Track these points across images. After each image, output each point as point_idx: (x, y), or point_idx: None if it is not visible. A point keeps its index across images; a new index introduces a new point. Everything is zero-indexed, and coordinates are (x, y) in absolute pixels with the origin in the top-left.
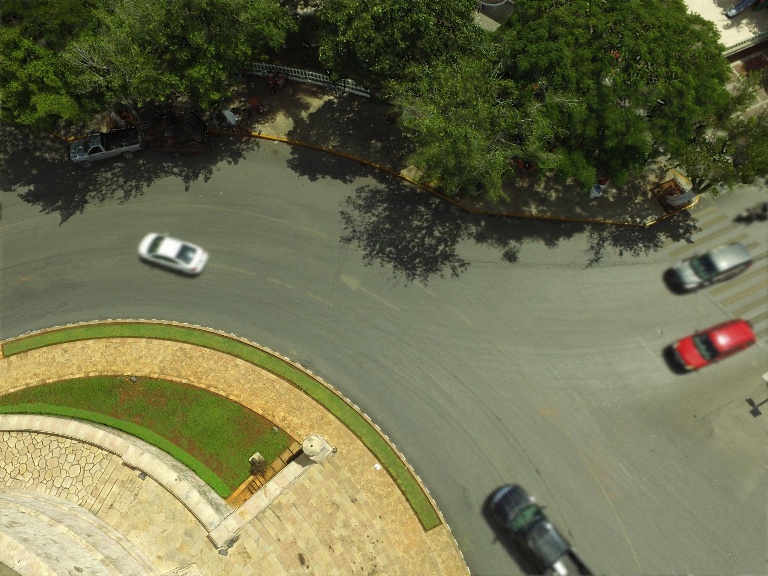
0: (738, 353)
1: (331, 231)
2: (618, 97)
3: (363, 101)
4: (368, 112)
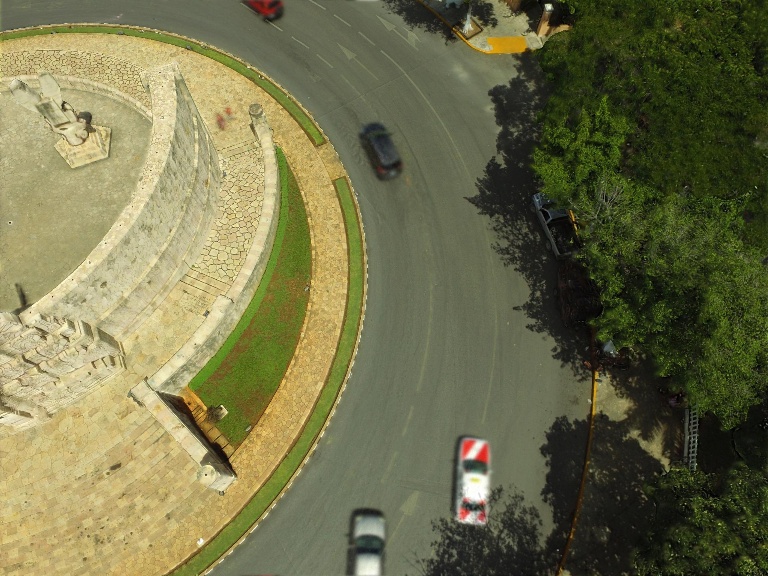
0: None
1: (475, 477)
2: None
3: None
4: None
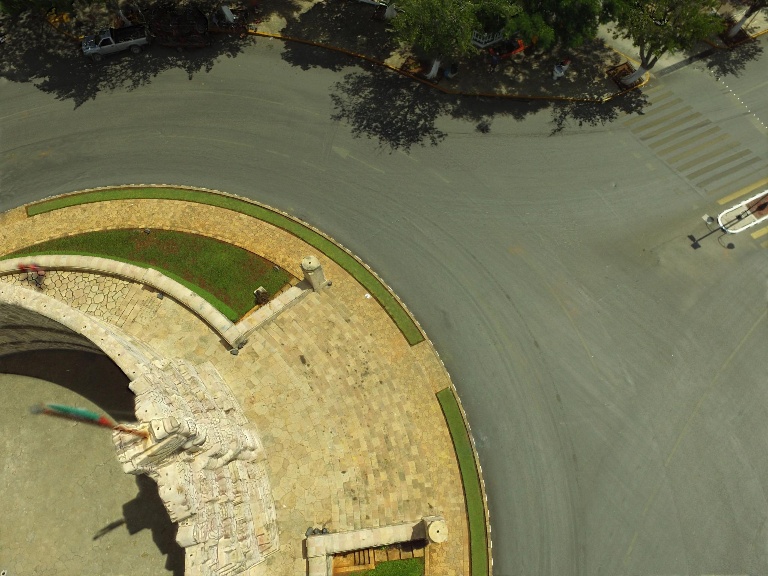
0: (681, 200)
1: (323, 110)
2: None
3: (349, 3)
4: (354, 12)
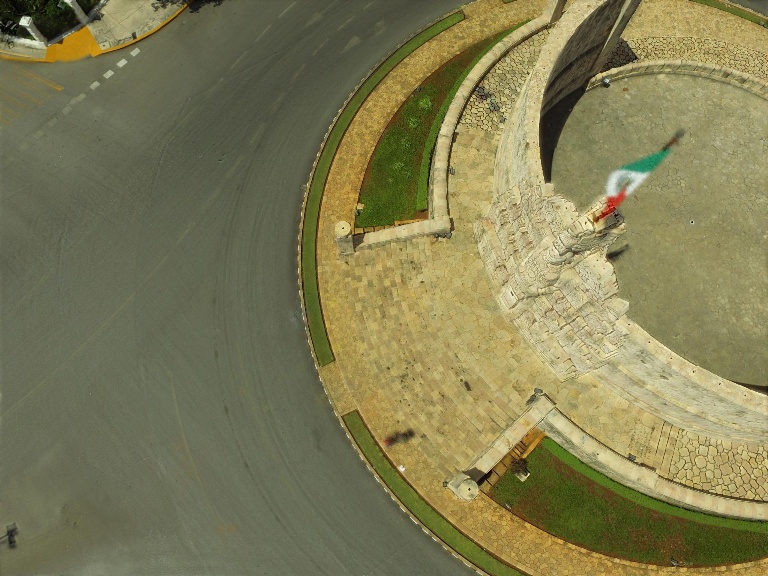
0: None
1: None
2: None
3: None
4: None
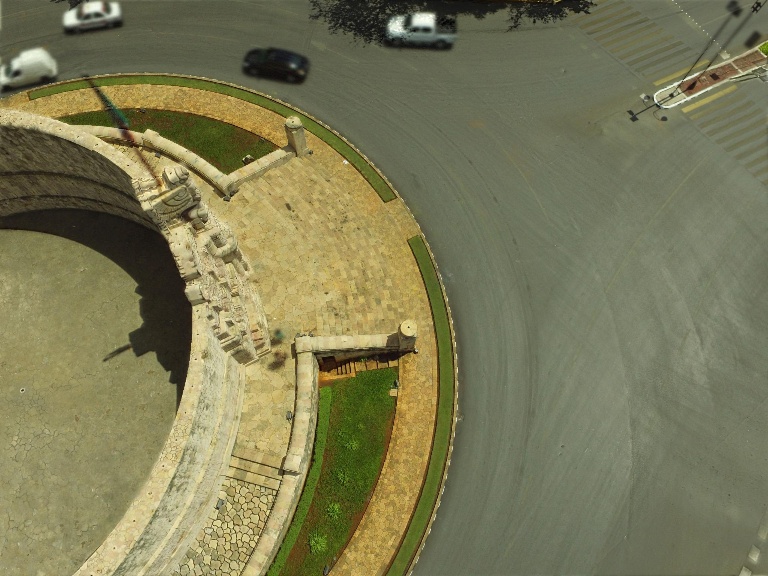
0: (622, 82)
1: (302, 11)
2: None
3: None
4: None
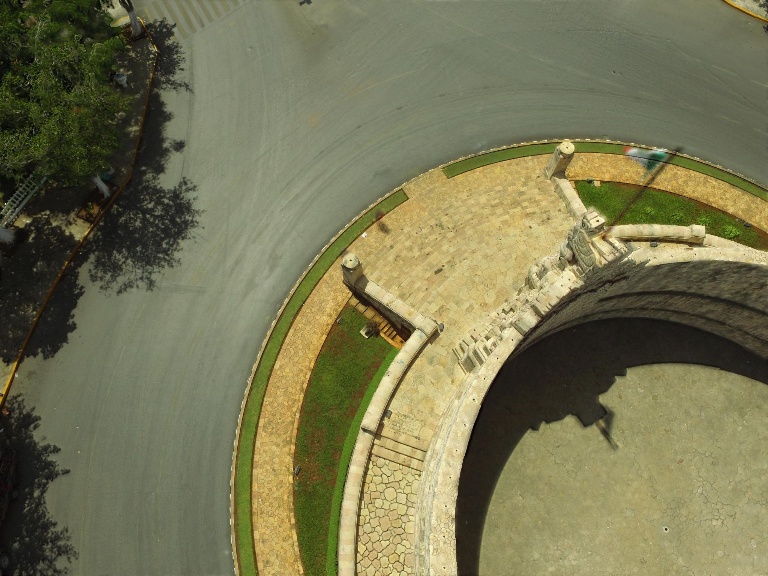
0: (266, 6)
1: (139, 300)
2: (41, 0)
3: None
4: None
